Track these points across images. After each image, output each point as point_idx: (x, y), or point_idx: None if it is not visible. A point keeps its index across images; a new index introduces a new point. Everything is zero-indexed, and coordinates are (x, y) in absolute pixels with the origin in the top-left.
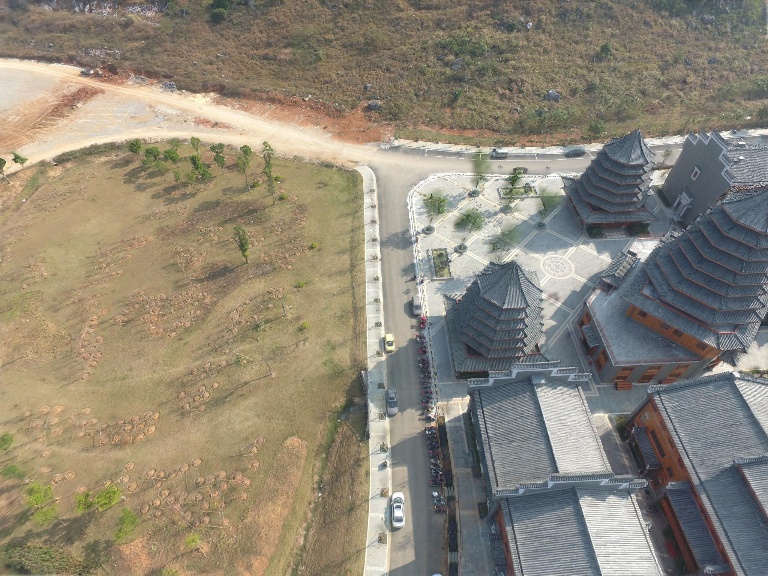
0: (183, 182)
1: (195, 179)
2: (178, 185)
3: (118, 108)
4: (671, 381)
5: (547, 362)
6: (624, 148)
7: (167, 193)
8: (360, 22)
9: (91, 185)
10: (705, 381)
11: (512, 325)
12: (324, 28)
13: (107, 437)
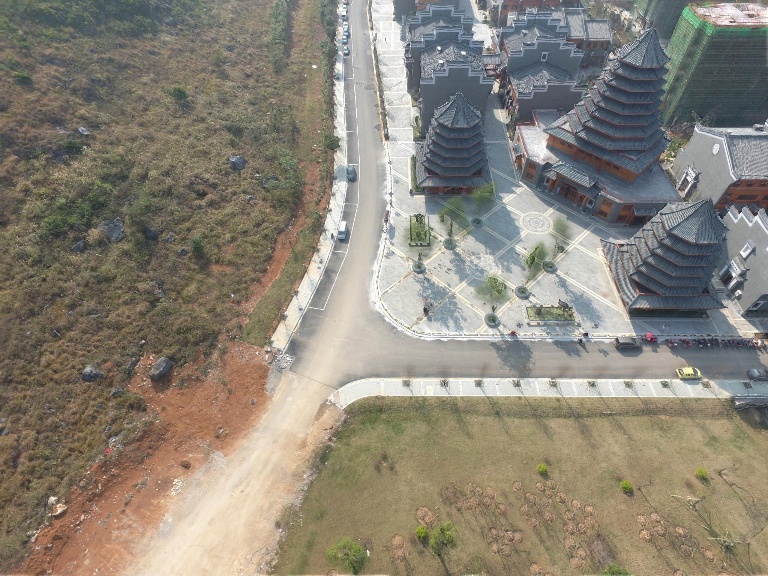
0: None
1: None
2: None
3: None
4: None
5: (765, 218)
6: (466, 113)
7: None
8: None
9: None
10: None
11: None
12: None
13: None
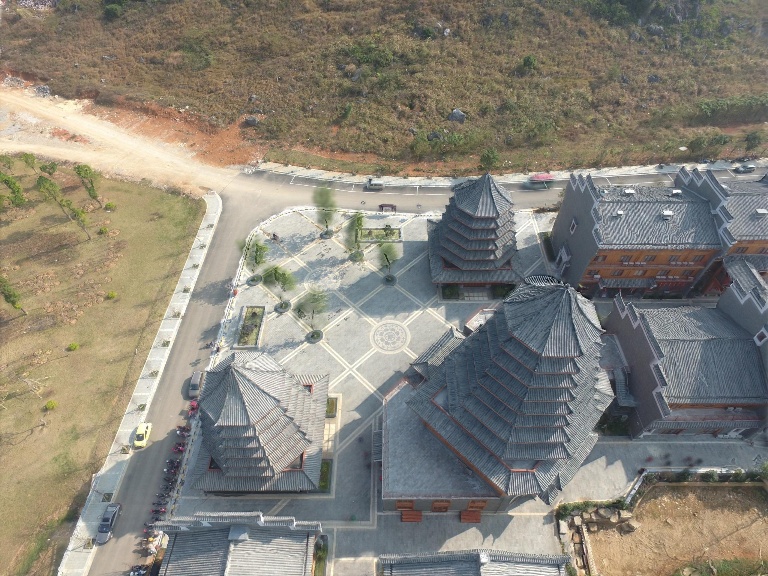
0: (5, 206)
1: None
2: None
3: None
4: (473, 513)
5: (243, 513)
6: (472, 195)
7: None
8: (260, 23)
9: None
10: (447, 559)
11: (242, 442)
12: (220, 29)
13: None
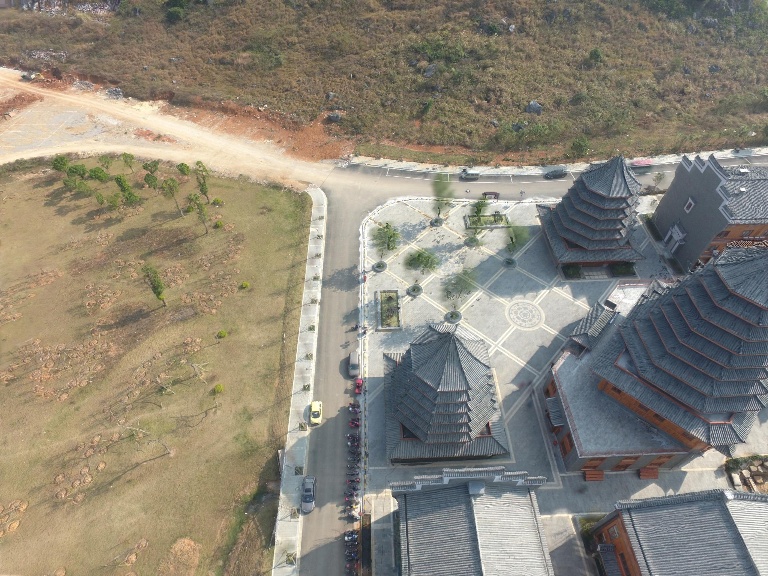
0: (110, 205)
1: (125, 201)
2: (104, 208)
3: (55, 117)
4: (652, 471)
5: (487, 468)
6: (604, 177)
7: (90, 218)
8: (326, 23)
9: (7, 207)
10: (689, 500)
11: (452, 408)
12: (287, 30)
13: None
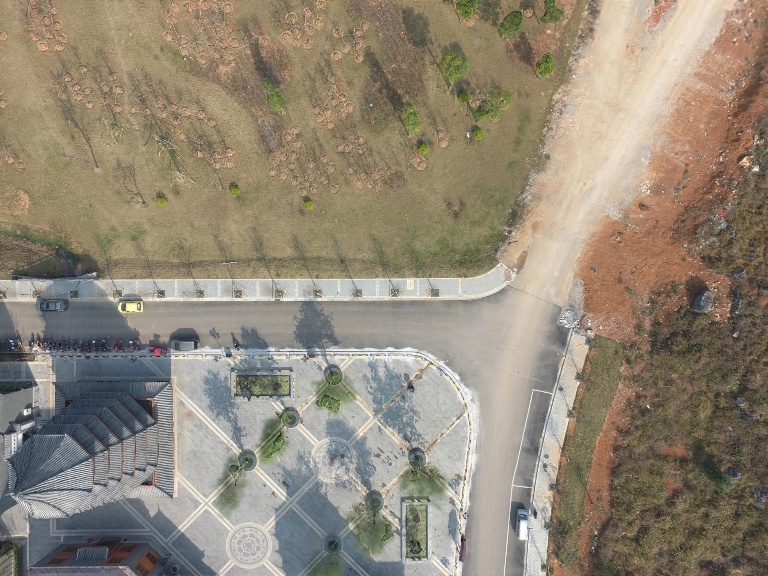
0: None
1: None
2: None
3: None
4: None
5: None
6: None
7: None
8: None
9: None
10: None
11: None
12: None
13: (36, 2)
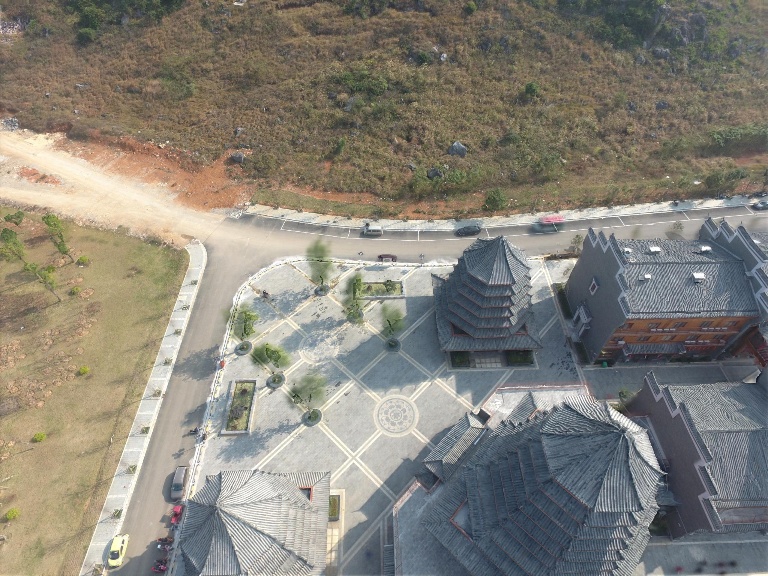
0: None
1: None
2: None
3: None
4: None
5: None
6: (485, 260)
7: None
8: (245, 49)
9: None
10: None
11: None
12: (202, 55)
13: None
